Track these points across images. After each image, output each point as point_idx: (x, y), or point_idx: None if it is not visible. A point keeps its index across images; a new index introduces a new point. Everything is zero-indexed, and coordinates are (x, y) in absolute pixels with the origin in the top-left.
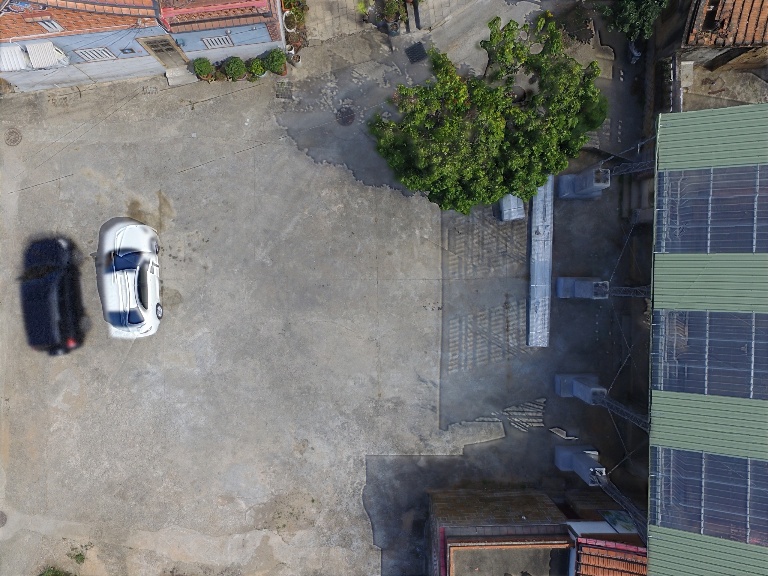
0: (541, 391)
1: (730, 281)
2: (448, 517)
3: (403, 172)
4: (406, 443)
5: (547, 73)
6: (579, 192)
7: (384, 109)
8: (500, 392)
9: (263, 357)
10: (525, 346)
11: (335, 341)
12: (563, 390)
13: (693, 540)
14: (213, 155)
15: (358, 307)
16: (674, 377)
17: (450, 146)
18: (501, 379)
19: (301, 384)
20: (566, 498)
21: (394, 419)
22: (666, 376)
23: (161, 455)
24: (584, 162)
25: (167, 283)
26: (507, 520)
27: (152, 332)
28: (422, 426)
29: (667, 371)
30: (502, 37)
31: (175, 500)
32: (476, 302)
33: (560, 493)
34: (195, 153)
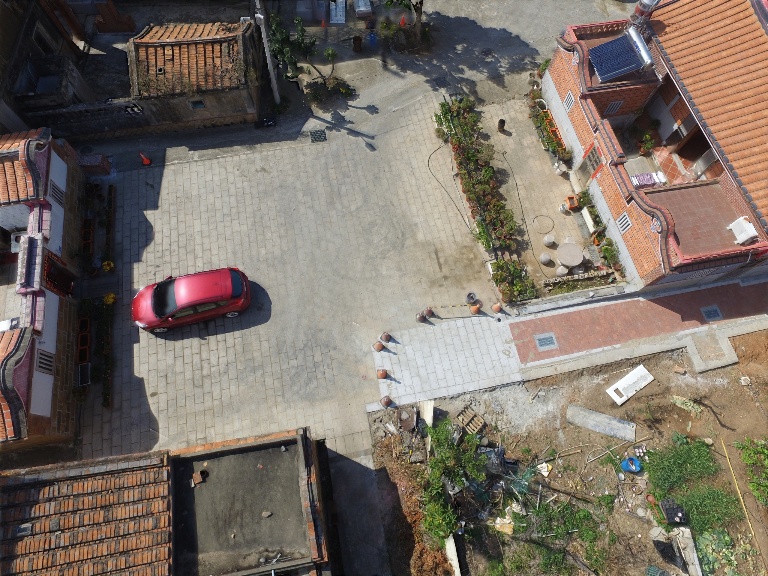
0: None
1: None
2: None
3: None
4: None
5: None
6: None
7: (461, 55)
8: None
9: None
10: None
11: None
12: None
13: None
14: None
15: None
16: None
17: None
18: None
19: None
20: None
21: None
22: None
23: None
24: None
25: None
26: None
27: None
28: None
29: None
30: None
31: None
32: None
33: None
34: None
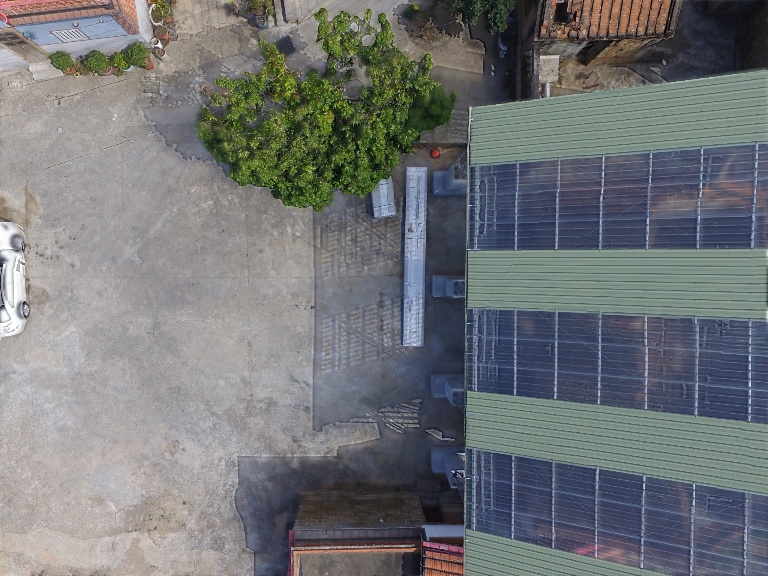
0: (417, 391)
1: (535, 279)
2: (305, 520)
3: (232, 167)
4: (279, 444)
5: (375, 66)
6: (448, 189)
7: None
8: (375, 392)
9: (132, 357)
10: (400, 346)
11: (205, 340)
12: (435, 390)
13: (504, 545)
14: (80, 151)
15: (229, 306)
16: (486, 377)
17: (261, 140)
18: (376, 379)
19: (171, 384)
20: (439, 500)
21: (266, 420)
22: (479, 376)
23: (29, 456)
24: None
25: (34, 281)
26: (363, 523)
27: (19, 331)
28: (295, 427)
29: (480, 371)
30: (331, 29)
31: (44, 502)
32: (349, 301)
33: (434, 495)
34: (62, 149)
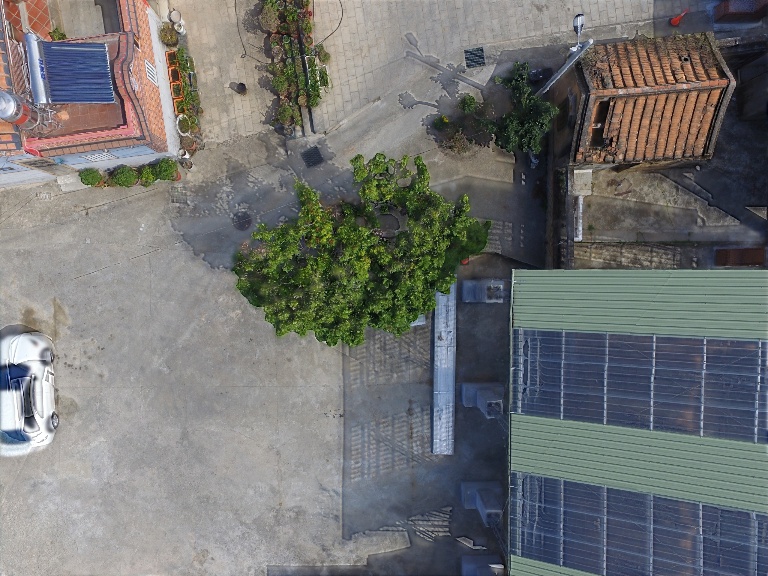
0: (447, 499)
1: (582, 451)
2: None
3: None
4: (308, 553)
5: (412, 211)
6: None
7: (281, 213)
8: (405, 501)
9: (161, 466)
10: (430, 453)
11: (234, 450)
12: (466, 502)
13: None
14: (108, 261)
15: (257, 415)
16: (531, 544)
17: (300, 299)
18: (405, 487)
19: (200, 493)
20: None
21: (296, 529)
22: (524, 542)
23: (59, 566)
24: (488, 265)
25: (63, 391)
26: None
27: (48, 441)
28: (324, 536)
29: (525, 537)
30: (367, 172)
31: None
32: (379, 409)
33: None
34: (90, 259)
